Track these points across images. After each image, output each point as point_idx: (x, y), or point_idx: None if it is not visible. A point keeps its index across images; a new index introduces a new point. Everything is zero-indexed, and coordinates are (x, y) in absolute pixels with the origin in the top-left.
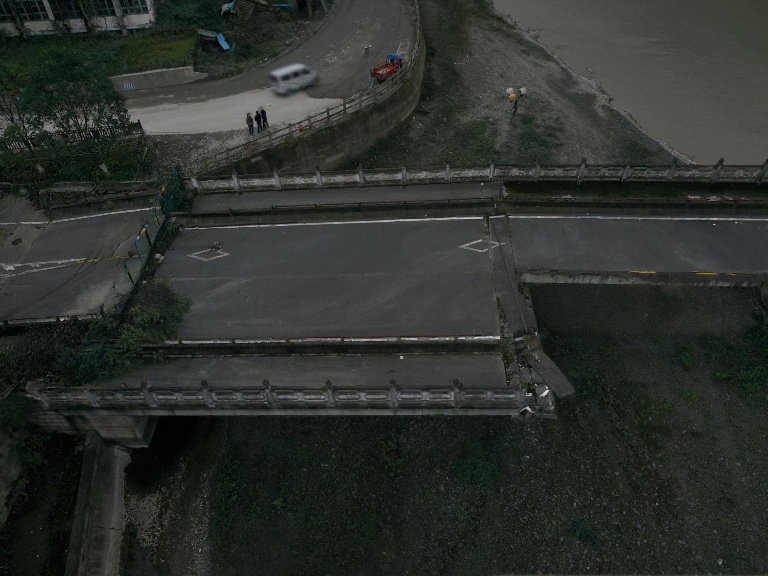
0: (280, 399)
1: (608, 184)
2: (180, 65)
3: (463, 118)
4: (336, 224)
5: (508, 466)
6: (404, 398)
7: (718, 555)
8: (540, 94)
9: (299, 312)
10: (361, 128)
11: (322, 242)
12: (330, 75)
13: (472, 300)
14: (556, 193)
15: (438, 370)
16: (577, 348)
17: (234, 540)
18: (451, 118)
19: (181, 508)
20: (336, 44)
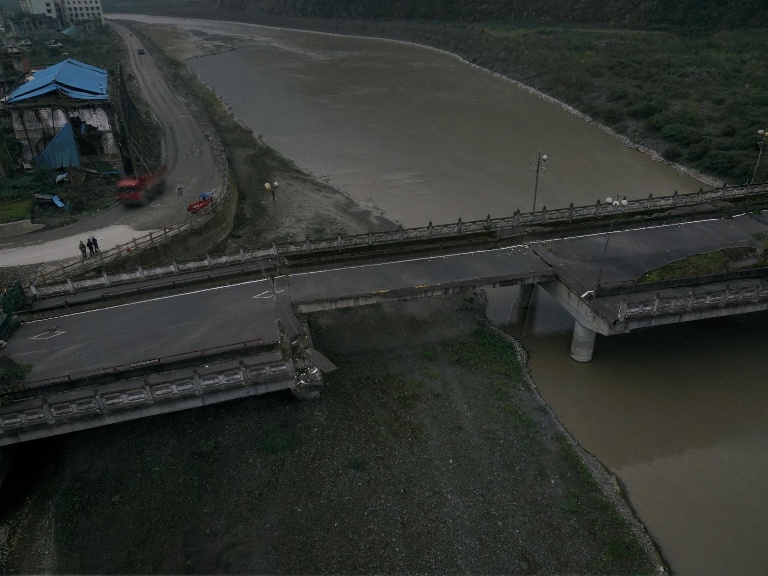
0: (109, 405)
1: (360, 249)
2: (18, 220)
3: (269, 236)
4: (156, 300)
5: (301, 437)
6: (206, 385)
7: (449, 458)
8: (329, 215)
9: (126, 356)
10: (182, 248)
11: (145, 312)
12: (154, 215)
13: (260, 326)
14: None
15: None
16: (354, 361)
17: (78, 536)
18: (259, 237)
19: (28, 530)
20: (159, 195)
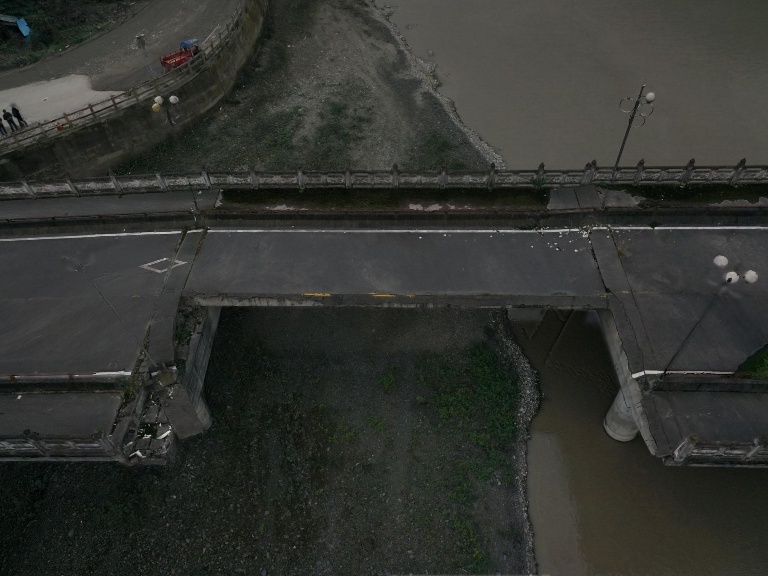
0: None
1: (332, 191)
2: None
3: (272, 108)
4: (30, 240)
5: (149, 507)
6: None
7: None
8: (364, 80)
9: None
10: (142, 123)
11: (5, 261)
12: (126, 64)
13: (124, 329)
14: (272, 202)
15: (49, 412)
16: (282, 370)
17: None
18: (259, 108)
19: None
20: (150, 28)
